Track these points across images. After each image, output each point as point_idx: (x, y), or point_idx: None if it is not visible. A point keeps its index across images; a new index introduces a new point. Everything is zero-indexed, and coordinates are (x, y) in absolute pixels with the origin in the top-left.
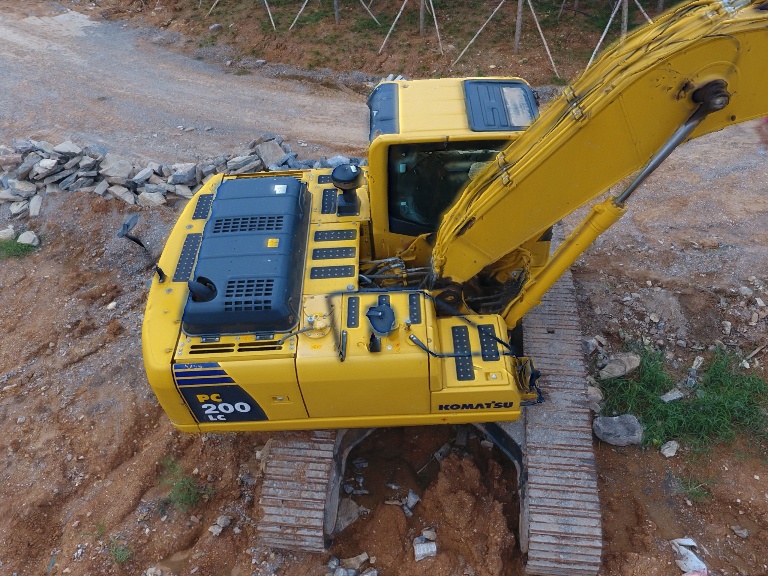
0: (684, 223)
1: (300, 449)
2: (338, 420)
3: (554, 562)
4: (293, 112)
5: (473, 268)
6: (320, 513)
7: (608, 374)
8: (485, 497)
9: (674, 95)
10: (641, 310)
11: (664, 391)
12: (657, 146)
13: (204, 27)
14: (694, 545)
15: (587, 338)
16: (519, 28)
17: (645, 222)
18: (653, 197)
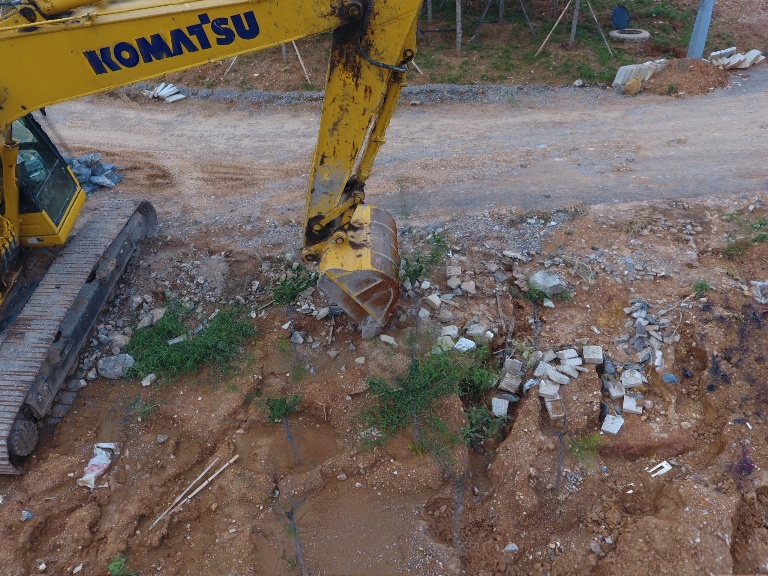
0: (301, 205)
1: None
2: None
3: None
4: (60, 118)
5: None
6: None
7: (141, 325)
8: None
9: None
10: (193, 274)
11: (175, 337)
12: None
13: None
14: (110, 447)
15: (134, 297)
16: None
17: (271, 205)
18: (300, 185)
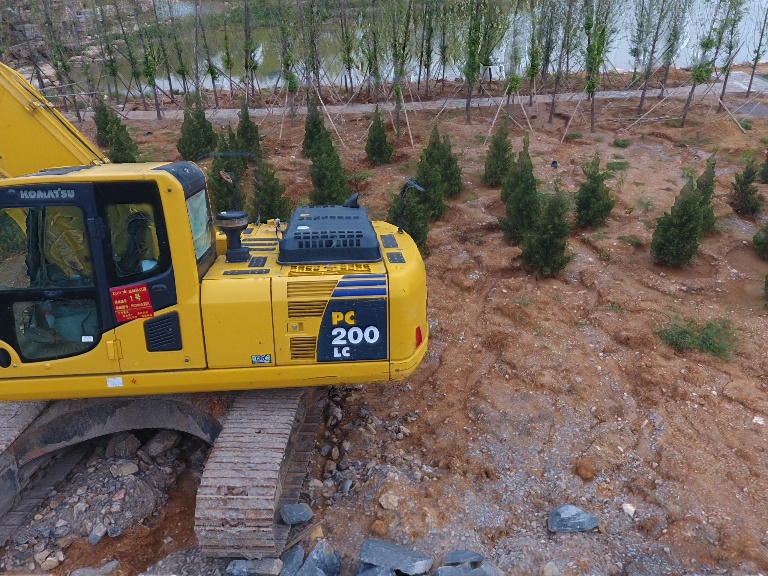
0: None
1: None
2: None
3: None
4: None
5: None
6: None
7: None
8: None
9: None
10: None
11: None
12: None
13: None
14: None
15: None
16: None
17: None
18: None
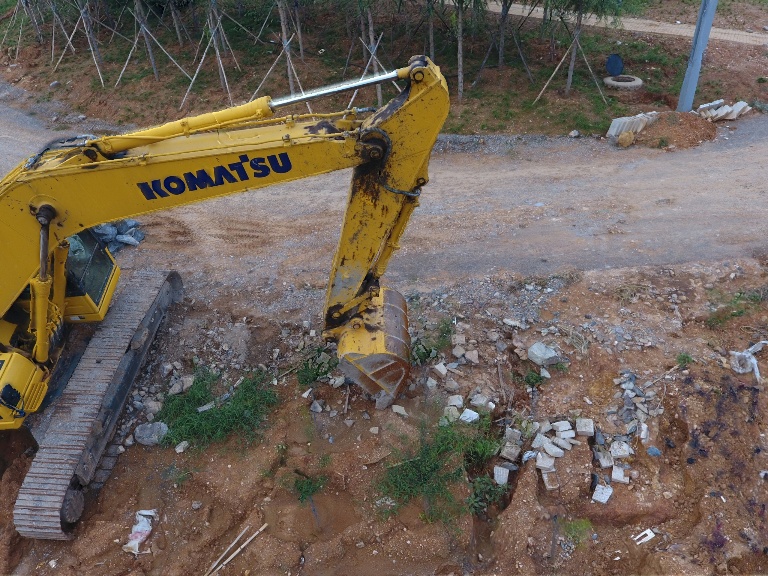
0: (315, 267)
1: None
2: None
3: (33, 528)
4: None
5: None
6: None
7: (172, 392)
8: None
9: (28, 213)
10: (218, 341)
11: (204, 404)
12: None
13: (47, 83)
14: (150, 515)
15: (165, 364)
16: (292, 88)
17: (287, 266)
18: (313, 244)
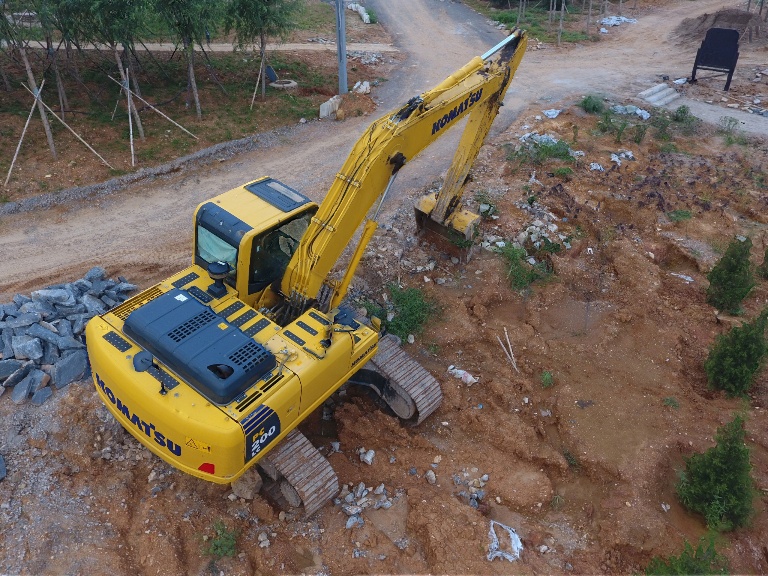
0: None
1: (288, 449)
2: (311, 408)
3: (428, 407)
4: None
5: (318, 287)
6: (330, 467)
7: None
8: (367, 415)
9: (385, 164)
10: None
11: None
12: (382, 188)
13: None
14: None
15: None
16: (51, 138)
17: None
18: None
